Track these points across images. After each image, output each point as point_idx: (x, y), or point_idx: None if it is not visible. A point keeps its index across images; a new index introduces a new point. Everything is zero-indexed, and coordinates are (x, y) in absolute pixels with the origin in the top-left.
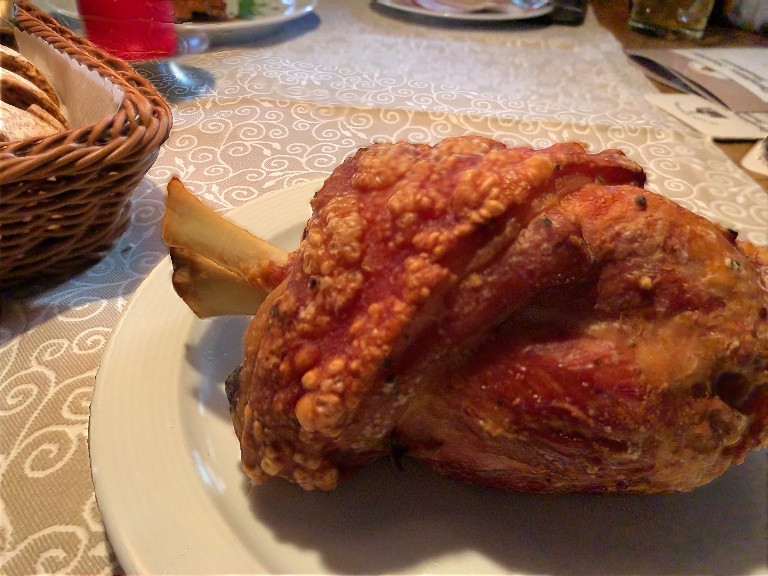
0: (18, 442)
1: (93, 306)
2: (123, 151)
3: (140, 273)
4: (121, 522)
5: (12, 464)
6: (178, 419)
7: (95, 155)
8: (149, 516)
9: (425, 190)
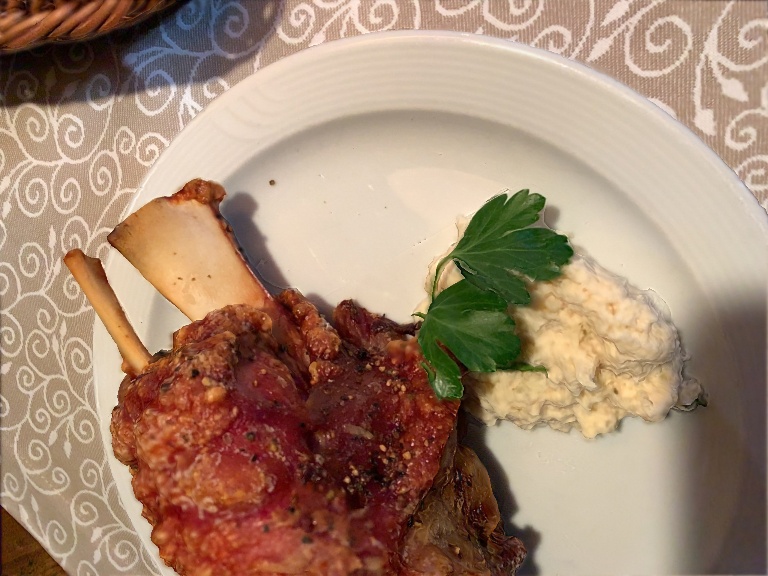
0: (96, 228)
1: (161, 97)
2: (115, 21)
3: (218, 45)
4: (97, 375)
5: (92, 244)
6: (148, 317)
7: (86, 26)
8: (110, 380)
9: (148, 501)
